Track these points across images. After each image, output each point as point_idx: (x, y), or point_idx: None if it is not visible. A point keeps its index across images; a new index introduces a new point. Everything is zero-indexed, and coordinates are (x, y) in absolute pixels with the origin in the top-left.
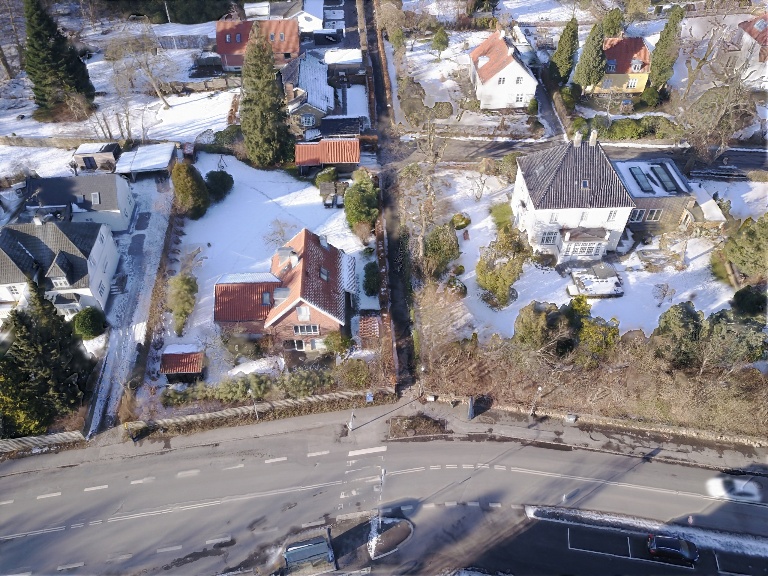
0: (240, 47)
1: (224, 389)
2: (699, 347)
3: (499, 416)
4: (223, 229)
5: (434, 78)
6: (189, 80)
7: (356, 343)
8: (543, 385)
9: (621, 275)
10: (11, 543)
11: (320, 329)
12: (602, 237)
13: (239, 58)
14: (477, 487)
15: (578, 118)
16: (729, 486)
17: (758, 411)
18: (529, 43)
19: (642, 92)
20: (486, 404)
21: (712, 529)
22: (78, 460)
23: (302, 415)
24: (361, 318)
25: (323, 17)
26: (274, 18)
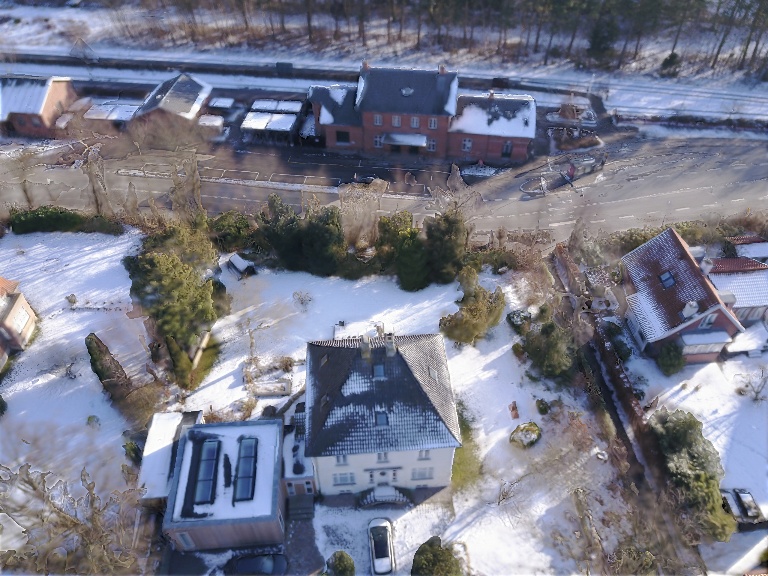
0: None
1: None
2: None
3: None
4: None
5: None
6: None
7: None
8: None
9: None
10: (761, 177)
11: None
12: None
13: None
14: None
15: None
16: None
17: None
18: None
19: None
20: None
21: (335, 194)
22: (767, 211)
23: None
24: (609, 282)
25: None
26: None
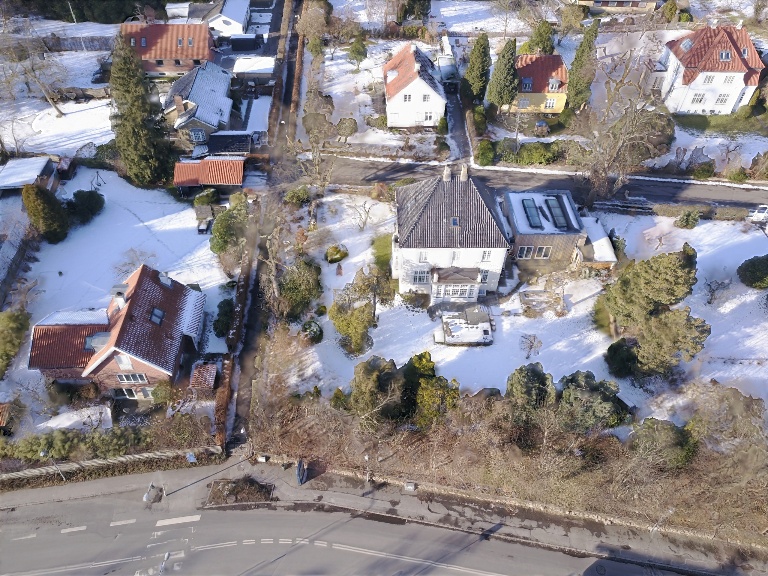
0: (145, 52)
1: (24, 447)
2: (542, 416)
3: (333, 481)
4: (81, 255)
5: (348, 91)
6: (91, 85)
7: (192, 392)
8: (385, 447)
9: (495, 320)
10: None
11: (148, 378)
12: (474, 279)
13: (145, 63)
14: (290, 567)
15: (483, 141)
16: (568, 571)
17: (611, 484)
18: (453, 55)
19: (561, 113)
20: (320, 467)
21: None
22: None
23: (116, 476)
24: (198, 365)
25: (248, 20)
26: (192, 20)
